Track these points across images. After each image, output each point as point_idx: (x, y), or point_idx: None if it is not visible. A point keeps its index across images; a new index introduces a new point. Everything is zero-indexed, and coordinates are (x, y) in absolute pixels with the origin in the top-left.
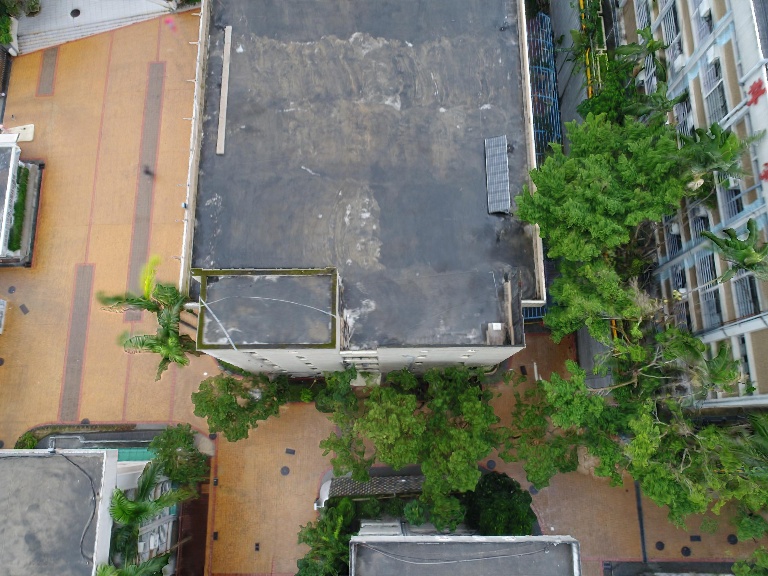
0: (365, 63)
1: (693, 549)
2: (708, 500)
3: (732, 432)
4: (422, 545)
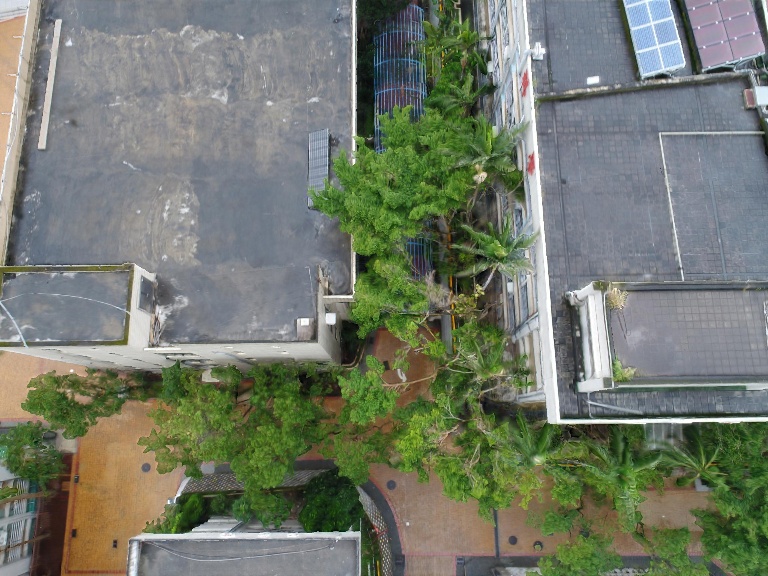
0: (194, 56)
1: (545, 543)
2: (507, 495)
3: (536, 427)
4: (207, 542)
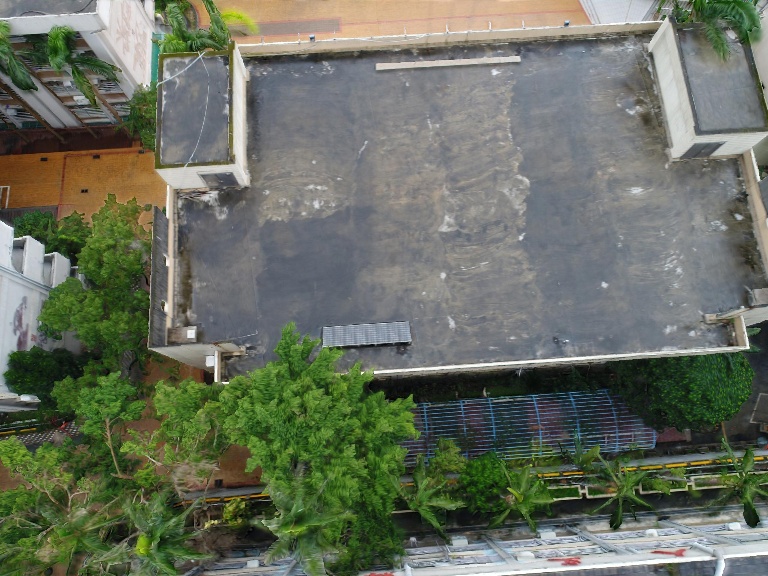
0: (492, 192)
1: None
2: None
3: None
4: None
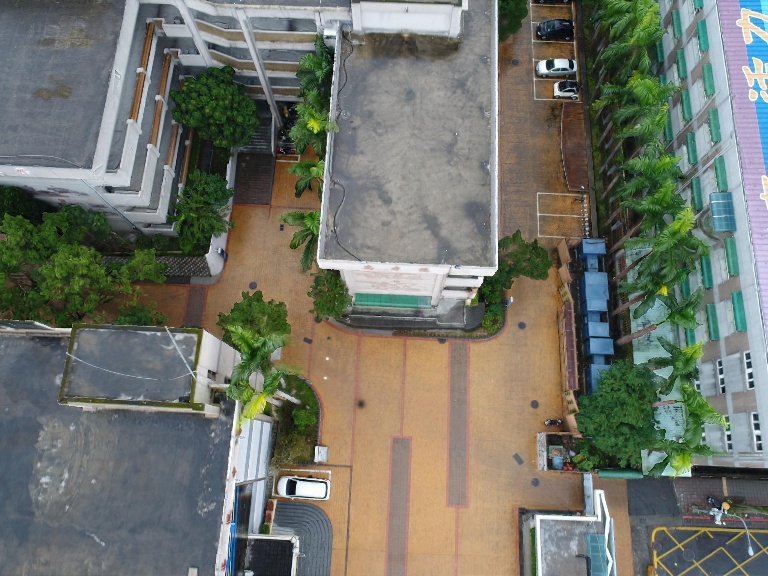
0: None
1: None
2: None
3: None
4: None
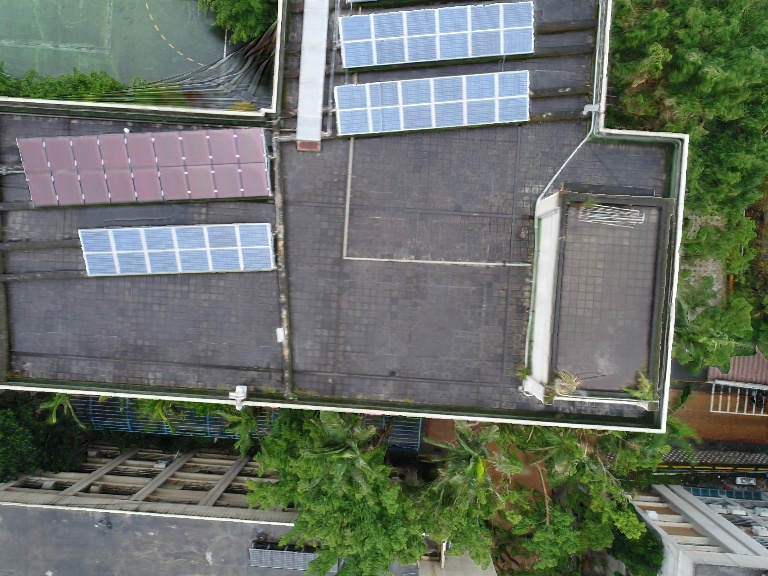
0: None
1: None
2: None
3: None
4: None
